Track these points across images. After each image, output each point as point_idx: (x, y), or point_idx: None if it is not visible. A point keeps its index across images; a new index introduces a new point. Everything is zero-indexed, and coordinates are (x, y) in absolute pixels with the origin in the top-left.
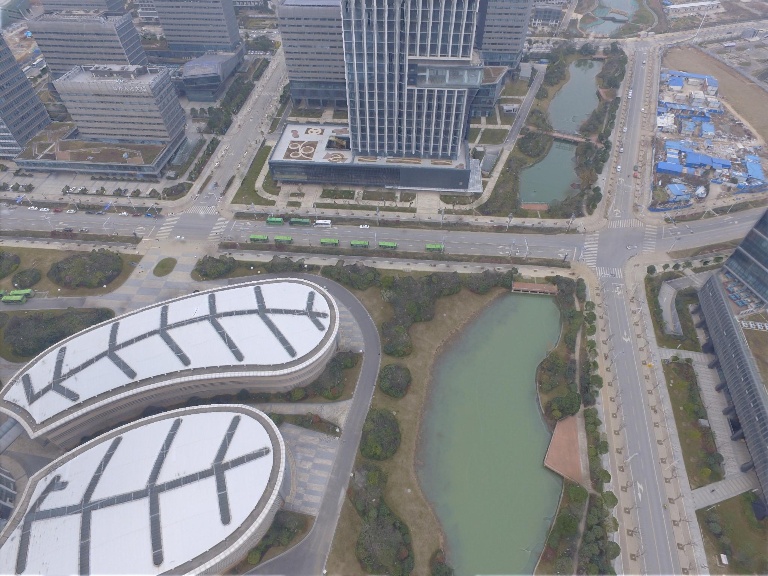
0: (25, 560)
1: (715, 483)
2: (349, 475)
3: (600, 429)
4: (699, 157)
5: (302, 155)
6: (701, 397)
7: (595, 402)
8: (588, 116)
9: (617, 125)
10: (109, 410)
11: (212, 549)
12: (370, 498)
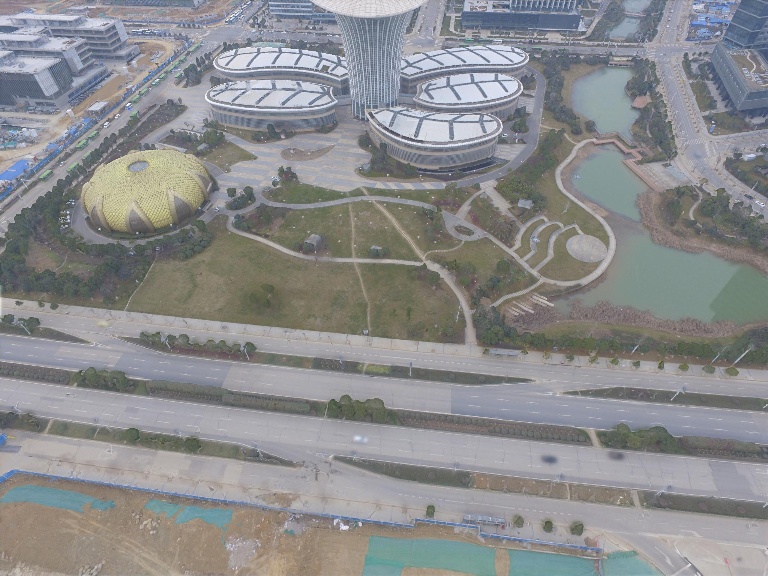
0: None
1: (712, 110)
2: (542, 106)
3: None
4: (718, 19)
5: (480, 10)
6: (708, 88)
7: None
8: (647, 7)
9: (667, 9)
10: None
11: (504, 97)
12: None
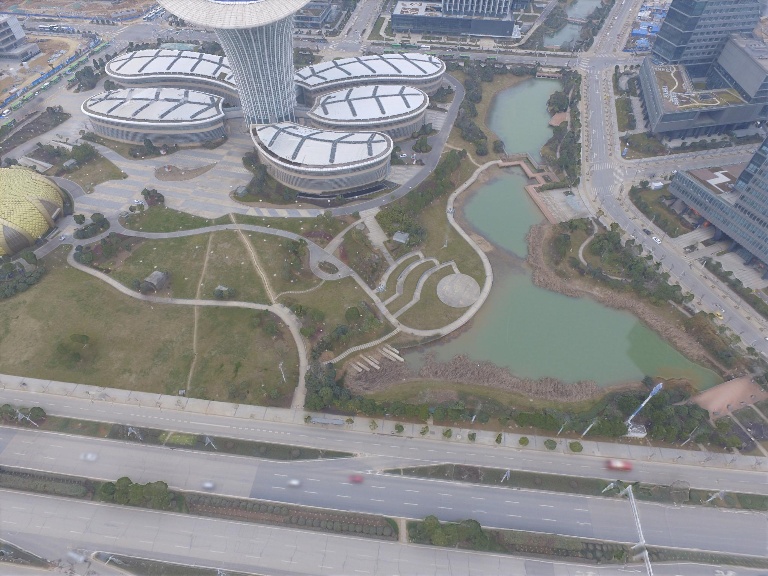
0: (327, 112)
1: (631, 130)
2: (454, 121)
3: None
4: None
5: (411, 13)
6: (631, 105)
7: None
8: (593, 12)
9: (611, 16)
10: None
11: (404, 114)
12: None
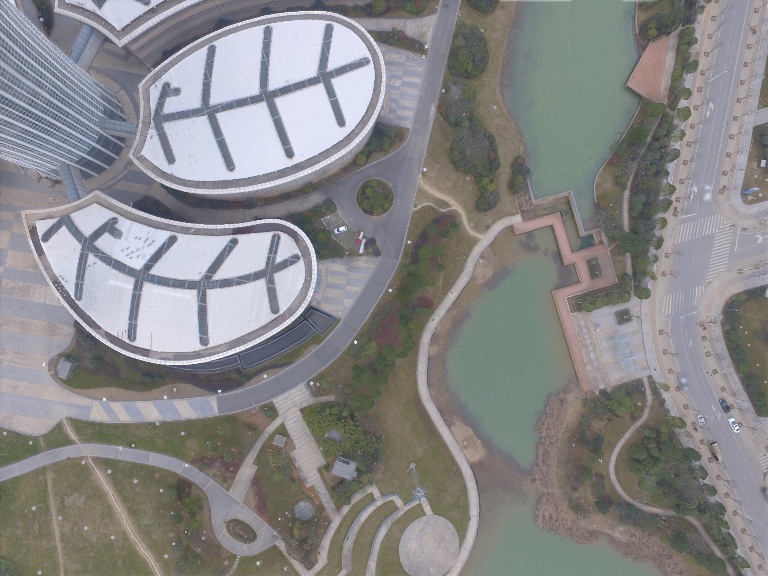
0: (172, 153)
1: None
2: (438, 93)
3: (693, 49)
4: None
5: None
6: None
7: (695, 21)
8: None
9: None
10: (182, 20)
11: (333, 147)
12: (460, 113)
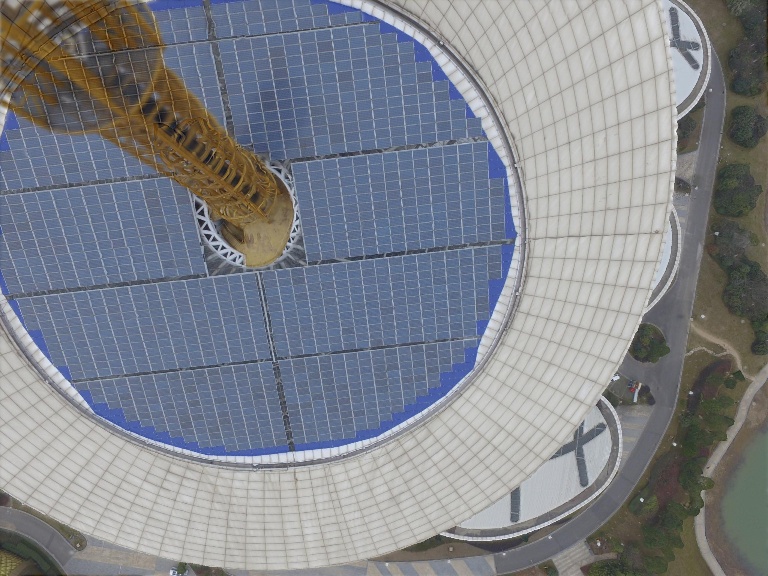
0: None
1: None
2: (704, 232)
3: None
4: None
5: None
6: None
7: None
8: None
9: None
10: None
11: None
12: (732, 254)
